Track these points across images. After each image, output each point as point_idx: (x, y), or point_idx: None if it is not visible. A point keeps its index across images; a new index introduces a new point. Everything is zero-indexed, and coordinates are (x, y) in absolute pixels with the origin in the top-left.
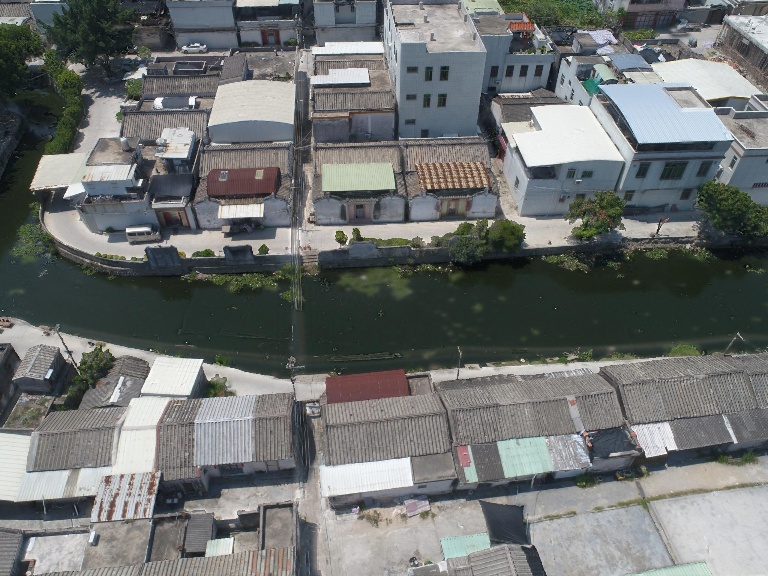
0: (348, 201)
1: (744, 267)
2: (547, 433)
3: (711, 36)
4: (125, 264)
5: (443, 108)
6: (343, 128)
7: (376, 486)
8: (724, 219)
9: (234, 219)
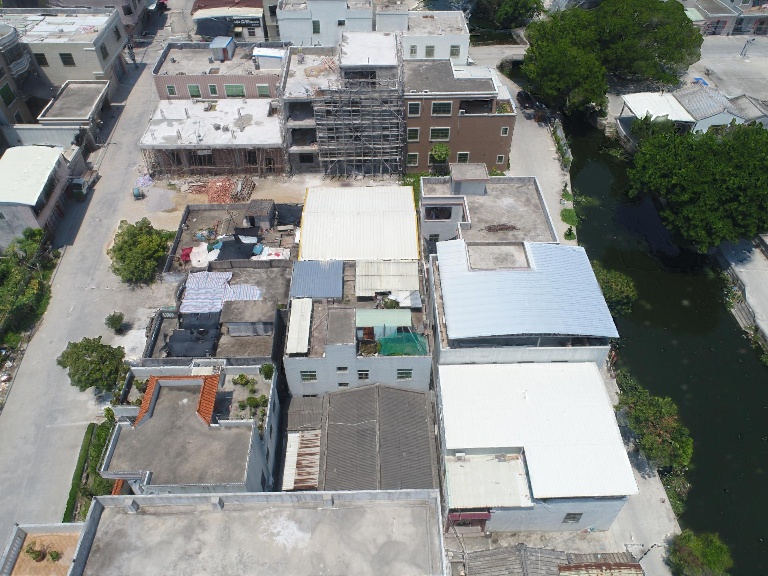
0: None
1: None
2: None
3: (119, 171)
4: None
5: None
6: None
7: None
8: None
9: None
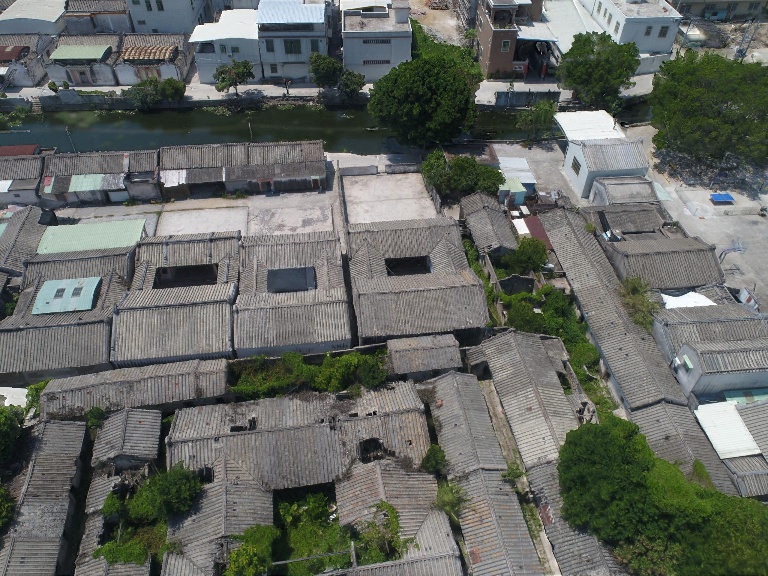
0: (69, 67)
1: (341, 115)
2: (105, 172)
3: None
4: None
5: (163, 12)
6: (88, 25)
7: None
8: (318, 77)
9: None
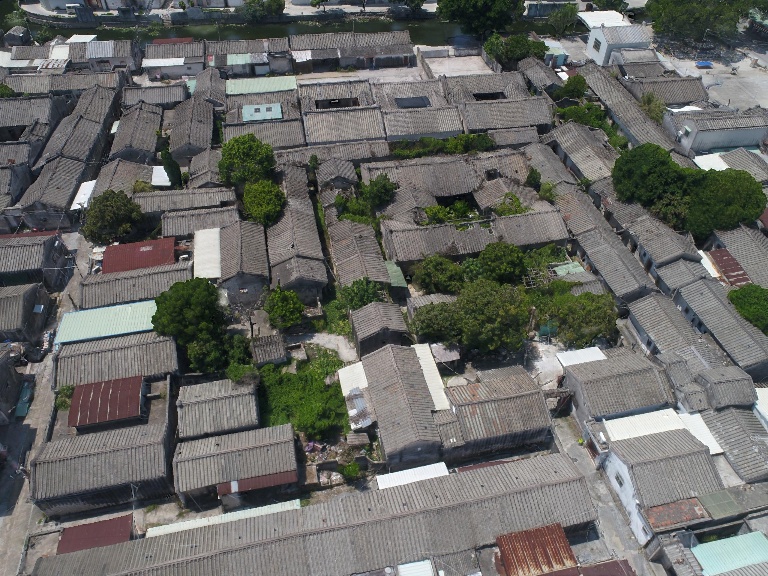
0: None
1: None
2: (251, 52)
3: None
4: (65, 20)
5: None
6: None
7: (167, 65)
8: None
9: (128, 4)
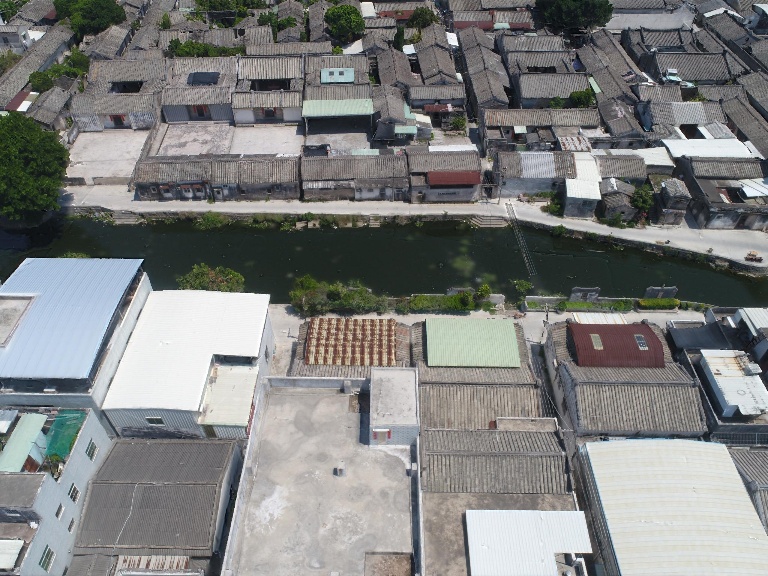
0: None
1: None
2: None
3: None
4: None
5: None
6: None
7: (448, 146)
8: None
9: None
